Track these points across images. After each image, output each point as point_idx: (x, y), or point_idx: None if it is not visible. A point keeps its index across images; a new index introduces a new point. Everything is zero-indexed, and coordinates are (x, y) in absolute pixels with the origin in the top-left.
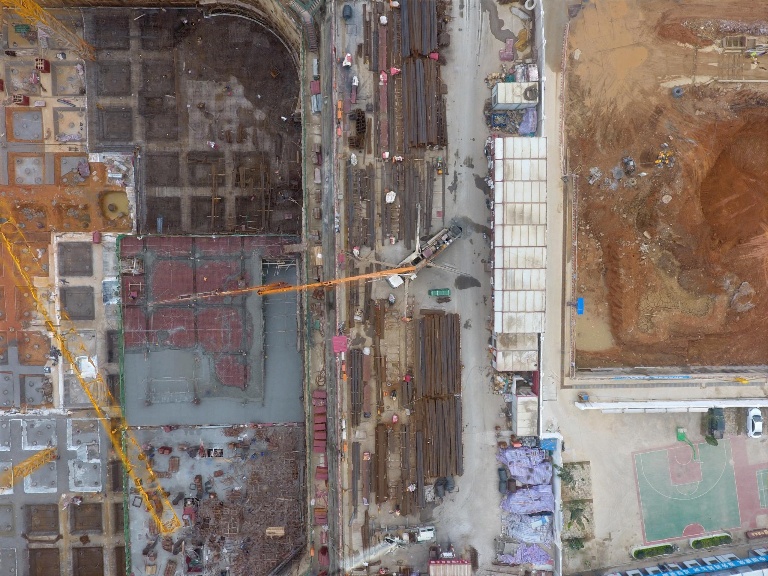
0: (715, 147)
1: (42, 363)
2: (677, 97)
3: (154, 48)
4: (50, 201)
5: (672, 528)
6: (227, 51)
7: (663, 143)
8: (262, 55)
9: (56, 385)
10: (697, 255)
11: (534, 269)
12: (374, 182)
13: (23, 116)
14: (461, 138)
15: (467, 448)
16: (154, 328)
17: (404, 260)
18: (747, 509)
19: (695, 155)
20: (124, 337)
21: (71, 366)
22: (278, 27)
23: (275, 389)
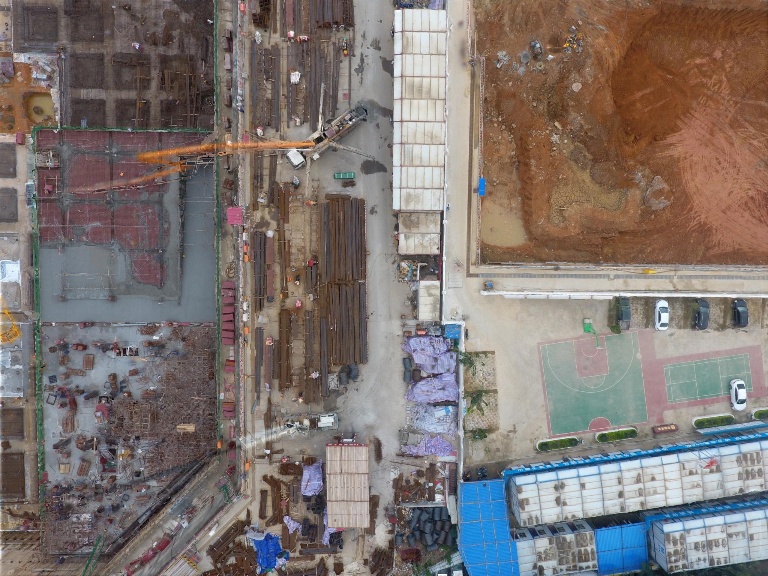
0: (626, 35)
1: None
2: None
3: None
4: None
5: (578, 421)
6: None
7: (572, 27)
8: None
9: None
10: (608, 147)
11: (433, 145)
12: (279, 62)
13: None
14: (368, 19)
15: (372, 337)
16: (70, 223)
17: (306, 139)
18: (654, 404)
19: (606, 42)
20: (40, 232)
21: None
22: None
23: (192, 288)
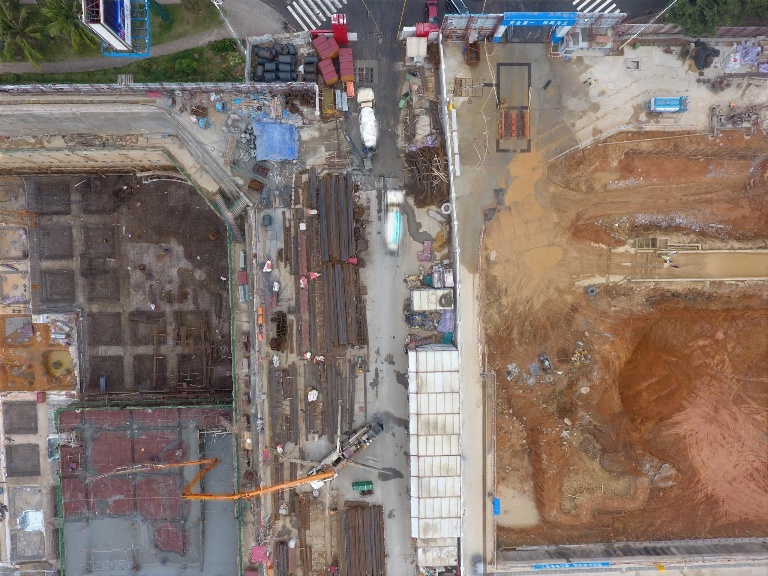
0: (631, 340)
1: None
2: (592, 296)
3: (95, 213)
4: None
5: None
6: (166, 215)
7: (579, 340)
8: (201, 218)
9: (3, 540)
10: (617, 441)
11: (449, 477)
12: (297, 380)
13: None
14: (382, 336)
15: None
16: (93, 497)
17: (325, 461)
18: None
19: (612, 348)
20: (64, 506)
21: (18, 521)
22: None
23: (214, 553)
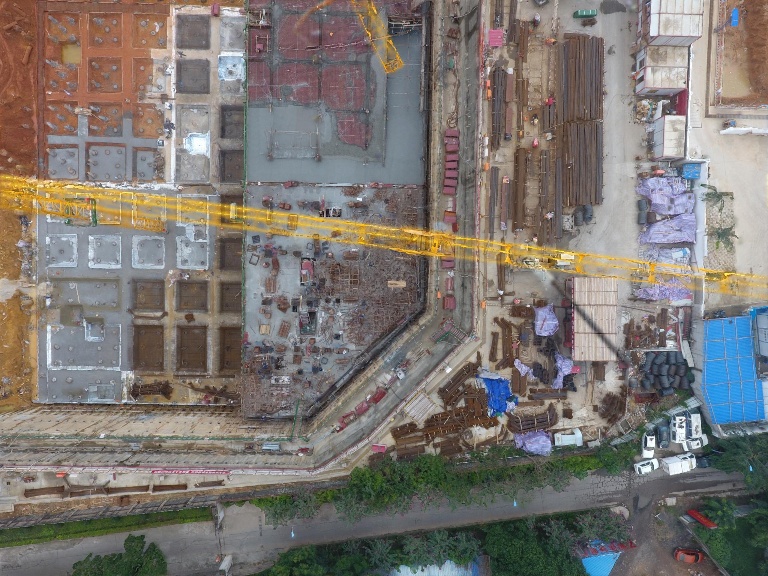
0: None
1: (155, 137)
2: None
3: None
4: None
5: None
6: None
7: None
8: None
9: (168, 159)
10: None
11: None
12: None
13: None
14: None
15: (606, 179)
16: (278, 83)
17: None
18: None
19: None
20: (248, 91)
21: (184, 140)
22: None
23: (396, 150)
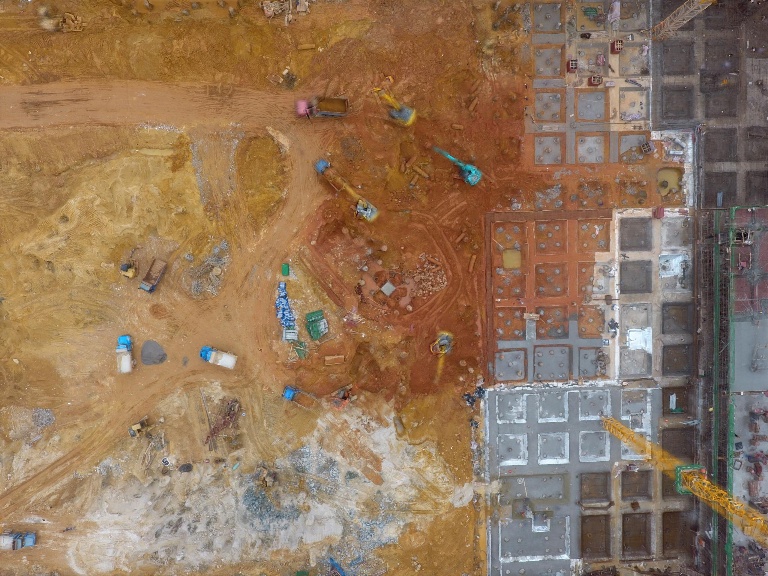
0: None
1: (598, 336)
2: None
3: (718, 28)
4: (613, 179)
5: None
6: None
7: None
8: None
9: (612, 357)
10: None
11: None
12: None
13: (587, 97)
14: None
15: None
16: (758, 297)
17: None
18: None
19: None
20: (730, 306)
21: (627, 338)
22: None
23: None
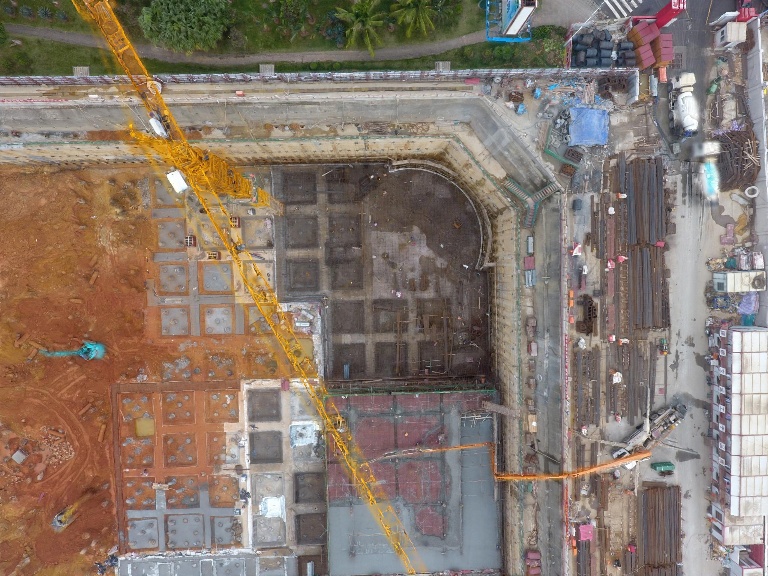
0: None
1: (231, 505)
2: None
3: (341, 202)
4: (240, 350)
5: None
6: (411, 203)
7: None
8: (445, 206)
9: (245, 526)
10: None
11: None
12: (600, 363)
13: (213, 269)
14: (683, 319)
15: None
16: (357, 482)
17: (635, 442)
18: None
19: None
20: (328, 491)
21: (260, 507)
22: (467, 185)
23: (472, 537)
